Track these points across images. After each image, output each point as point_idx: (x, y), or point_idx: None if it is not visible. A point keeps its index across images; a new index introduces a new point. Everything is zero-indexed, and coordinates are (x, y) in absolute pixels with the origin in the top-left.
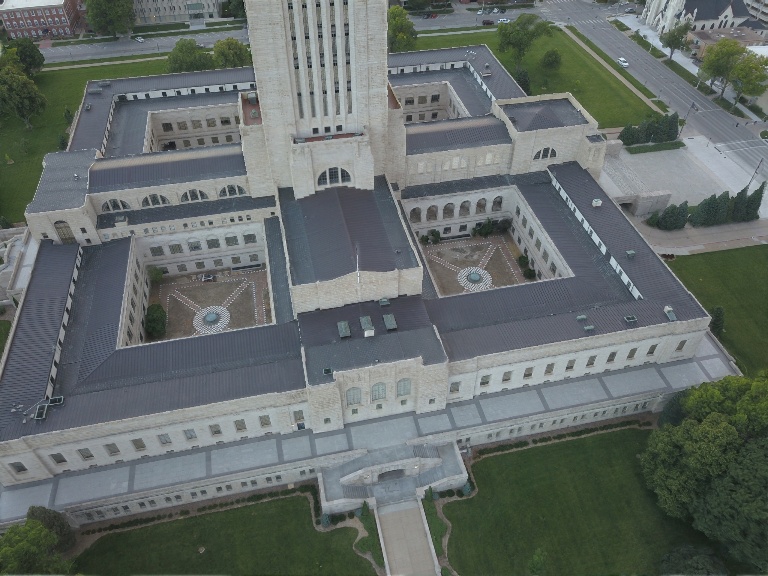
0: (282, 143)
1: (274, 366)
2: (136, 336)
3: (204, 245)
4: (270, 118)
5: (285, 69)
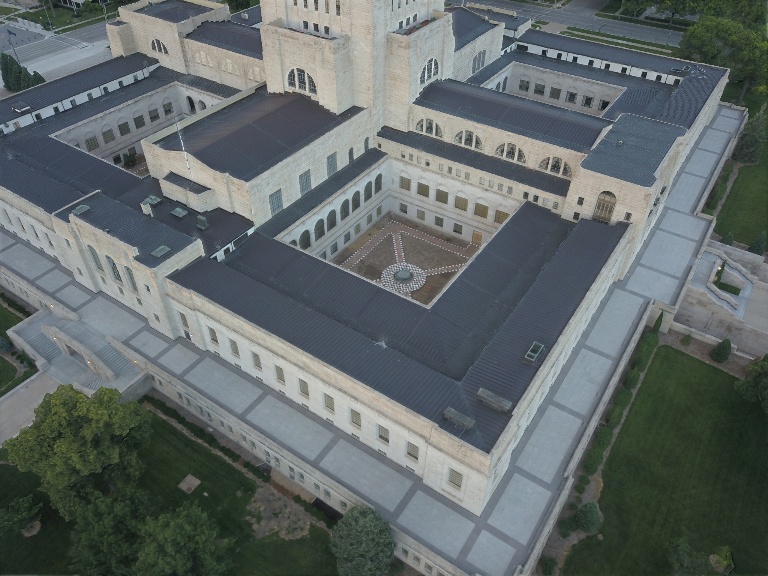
0: None
1: (536, 43)
2: None
3: None
4: None
5: None
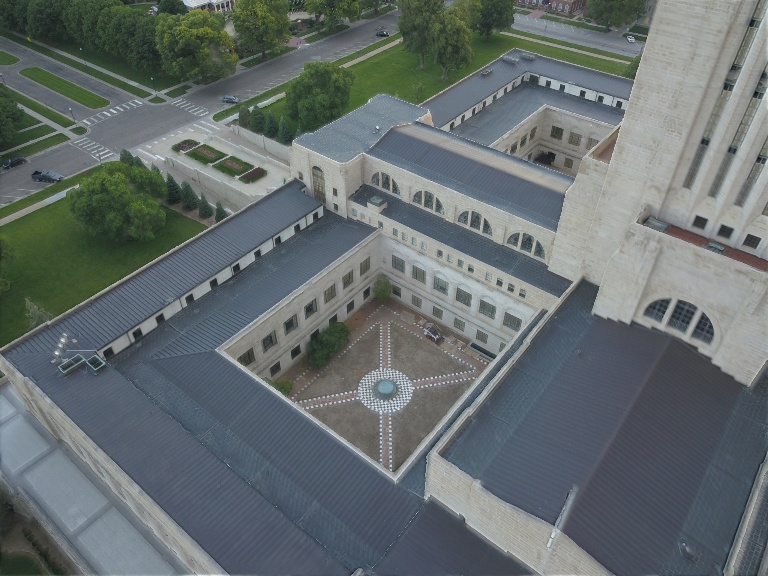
0: (626, 212)
1: (312, 552)
2: (283, 347)
3: (452, 292)
4: (626, 160)
5: (700, 80)
